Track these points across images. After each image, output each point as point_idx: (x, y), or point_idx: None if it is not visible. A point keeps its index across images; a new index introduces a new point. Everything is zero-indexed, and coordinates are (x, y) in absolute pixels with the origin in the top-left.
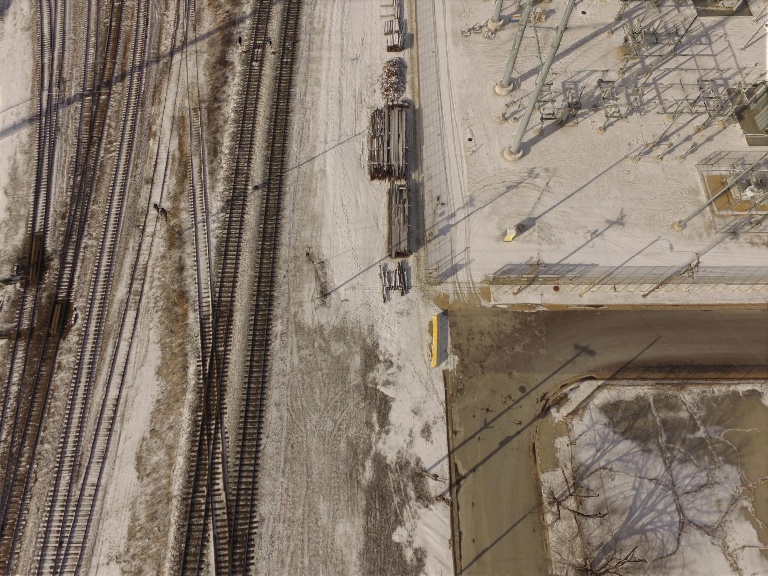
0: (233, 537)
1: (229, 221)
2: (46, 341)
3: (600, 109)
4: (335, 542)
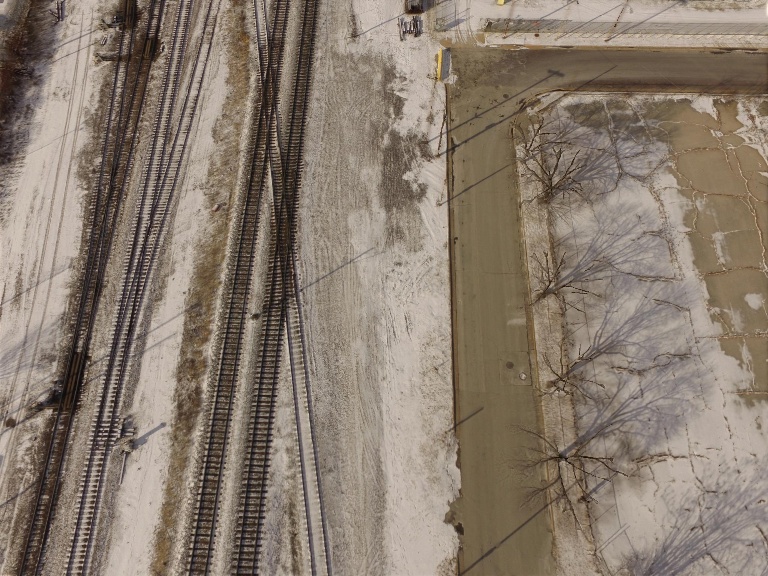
0: (285, 172)
1: None
2: (141, 62)
3: None
4: (360, 178)
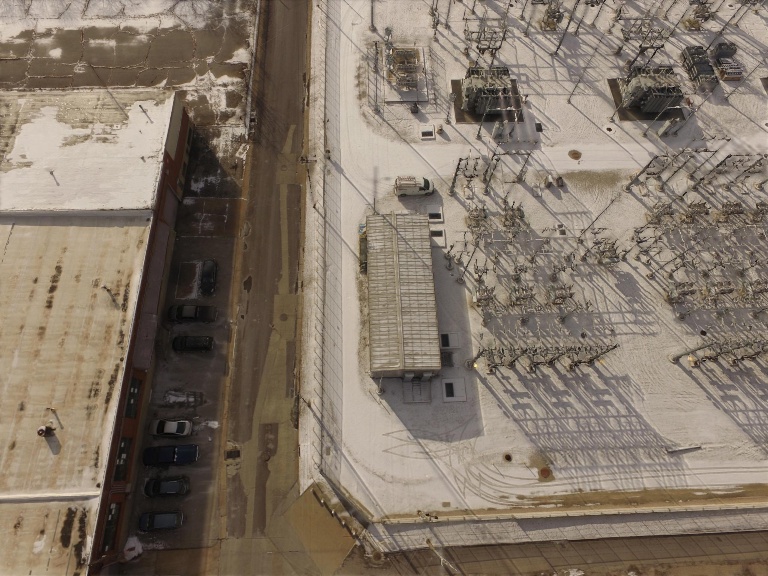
0: None
1: None
2: None
3: (480, 1)
4: None
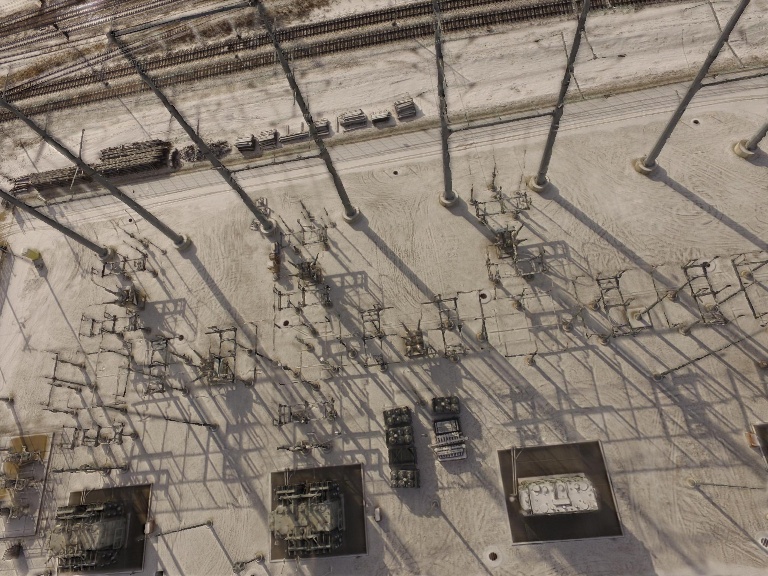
0: None
1: (85, 78)
2: (35, 23)
3: (145, 335)
4: None
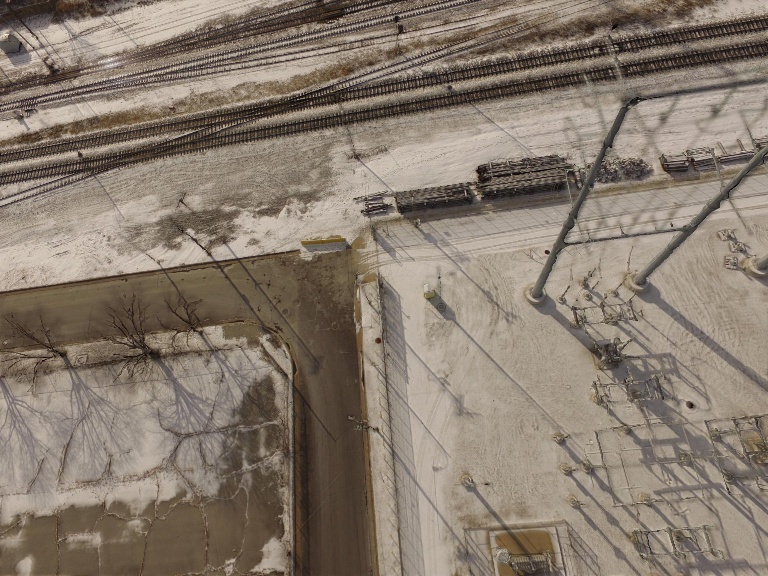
0: (196, 141)
1: (415, 79)
2: (316, 15)
3: None
4: (189, 196)
